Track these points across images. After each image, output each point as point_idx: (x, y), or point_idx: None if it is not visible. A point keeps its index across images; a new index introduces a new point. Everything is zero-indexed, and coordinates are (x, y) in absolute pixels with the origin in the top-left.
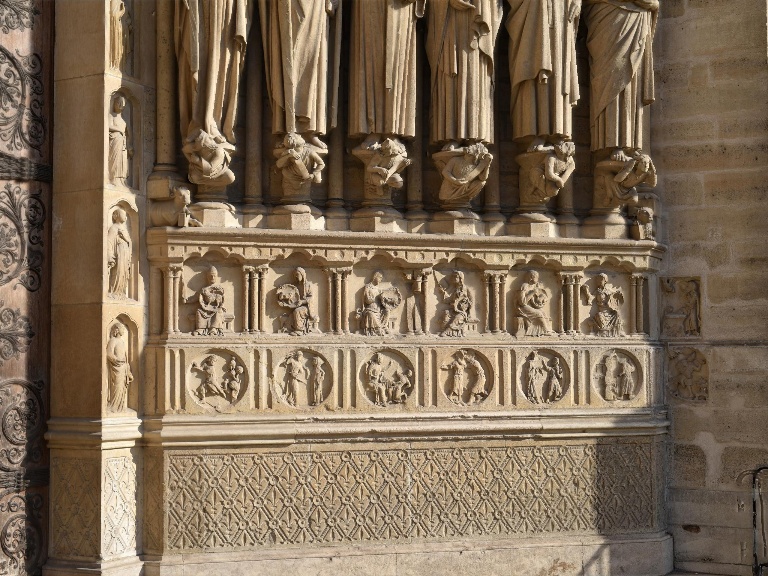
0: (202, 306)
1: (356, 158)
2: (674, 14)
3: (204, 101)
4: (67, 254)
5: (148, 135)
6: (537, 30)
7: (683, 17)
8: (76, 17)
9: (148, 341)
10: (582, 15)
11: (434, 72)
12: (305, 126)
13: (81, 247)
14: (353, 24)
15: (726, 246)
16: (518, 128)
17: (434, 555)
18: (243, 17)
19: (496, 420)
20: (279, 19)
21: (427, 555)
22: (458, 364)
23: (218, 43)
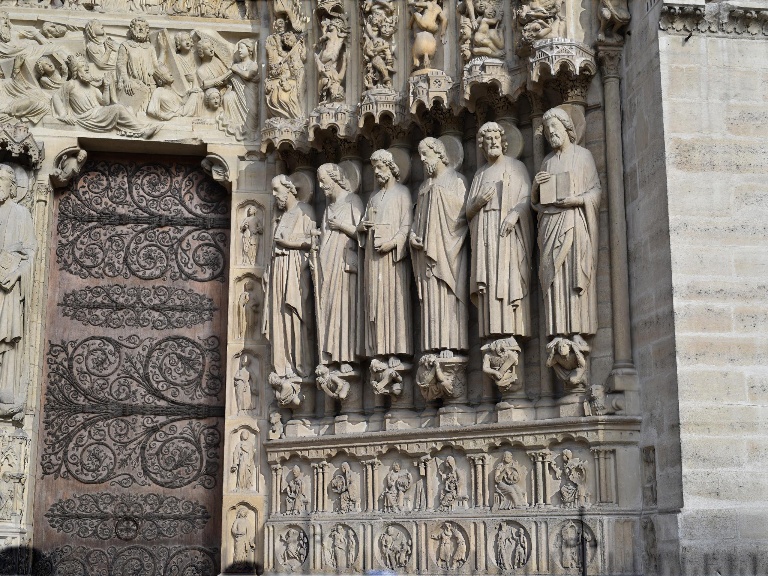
0: (289, 494)
1: None
2: (635, 197)
3: None
4: None
5: None
6: None
7: (638, 199)
8: None
9: None
10: None
11: None
12: None
13: None
14: None
15: (662, 414)
16: None
17: None
18: (291, 290)
19: None
20: None
21: None
22: (444, 535)
23: (279, 311)
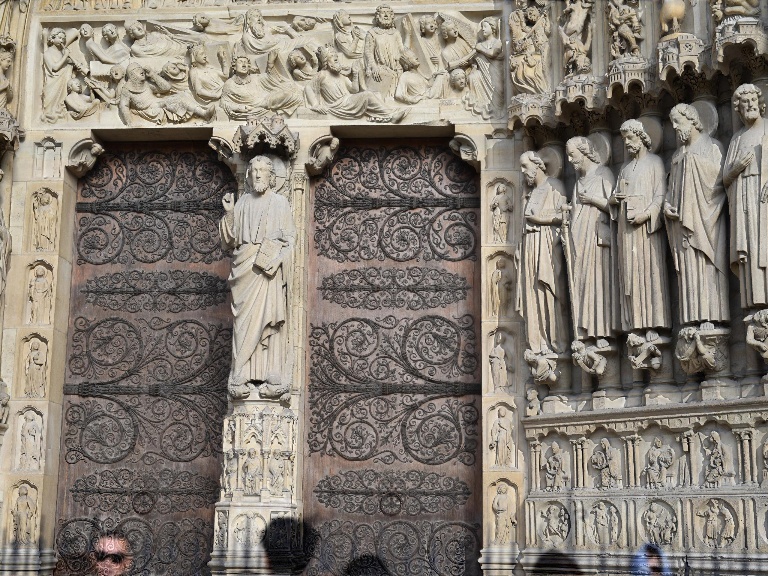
0: (548, 471)
1: None
2: None
3: None
4: None
5: None
6: None
7: None
8: None
9: None
10: None
11: None
12: None
13: None
14: None
15: None
16: None
17: None
18: (543, 266)
19: (740, 561)
20: None
21: None
22: (711, 512)
23: (532, 288)
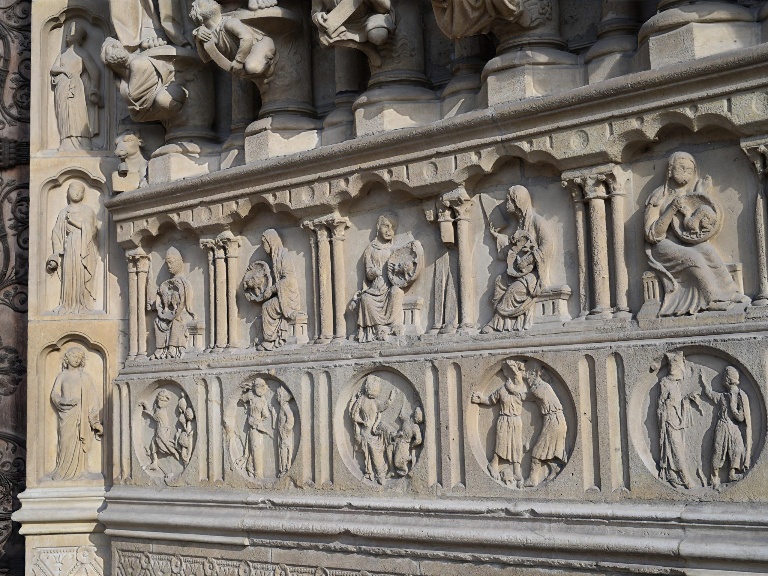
0: (158, 313)
1: None
2: None
3: None
4: None
5: None
6: None
7: None
8: None
9: None
10: None
11: None
12: None
13: None
14: None
15: None
16: None
17: None
18: None
19: (581, 524)
20: None
21: None
22: (506, 392)
23: None
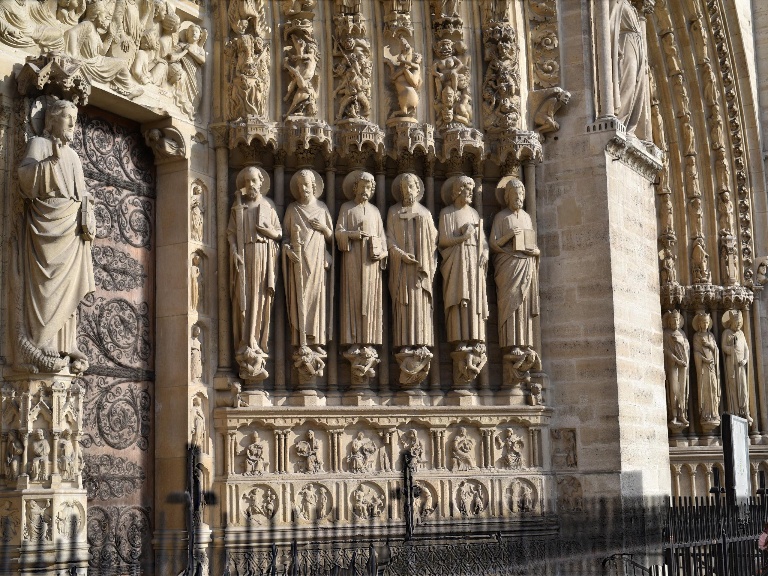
0: (249, 457)
1: (346, 358)
2: (554, 254)
3: (249, 328)
4: (165, 426)
5: (214, 349)
6: (459, 273)
7: (560, 257)
8: (170, 278)
9: (215, 480)
10: (491, 259)
11: (394, 302)
12: (312, 341)
13: (174, 422)
14: (342, 274)
15: (591, 408)
16: (450, 336)
17: None
18: (273, 275)
19: (440, 527)
20: (295, 275)
21: None
22: None
23: (257, 292)
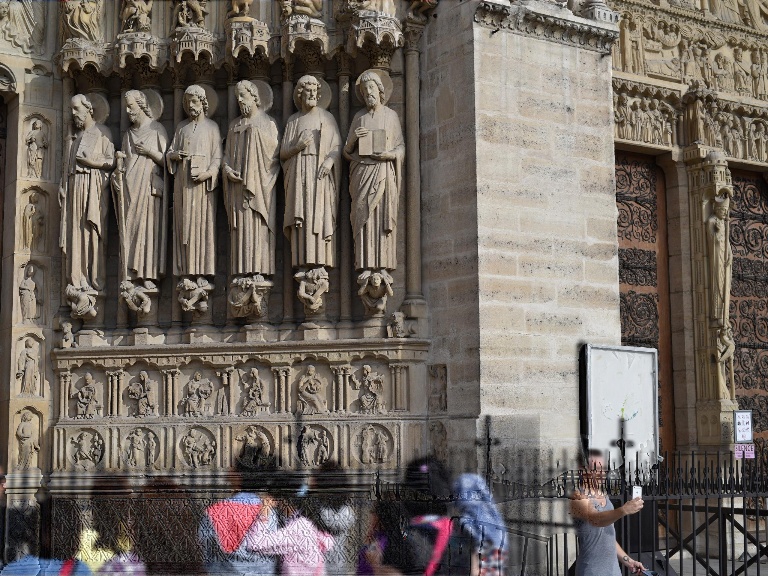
0: (80, 400)
1: None
2: (433, 156)
3: None
4: (2, 369)
5: (55, 288)
6: None
7: (437, 158)
8: None
9: None
10: None
11: (229, 227)
12: (136, 275)
13: None
14: None
15: (458, 339)
16: None
17: (225, 575)
18: (93, 207)
19: (275, 478)
20: None
21: (220, 575)
22: (249, 436)
23: (78, 226)
